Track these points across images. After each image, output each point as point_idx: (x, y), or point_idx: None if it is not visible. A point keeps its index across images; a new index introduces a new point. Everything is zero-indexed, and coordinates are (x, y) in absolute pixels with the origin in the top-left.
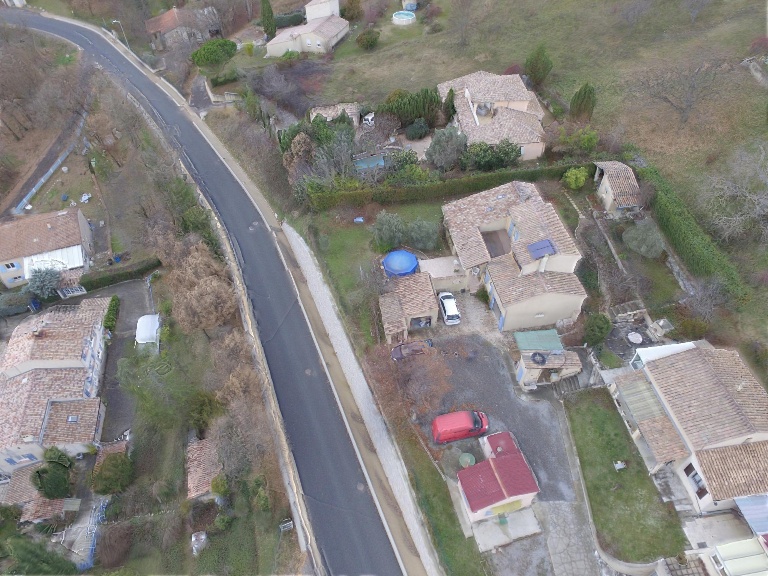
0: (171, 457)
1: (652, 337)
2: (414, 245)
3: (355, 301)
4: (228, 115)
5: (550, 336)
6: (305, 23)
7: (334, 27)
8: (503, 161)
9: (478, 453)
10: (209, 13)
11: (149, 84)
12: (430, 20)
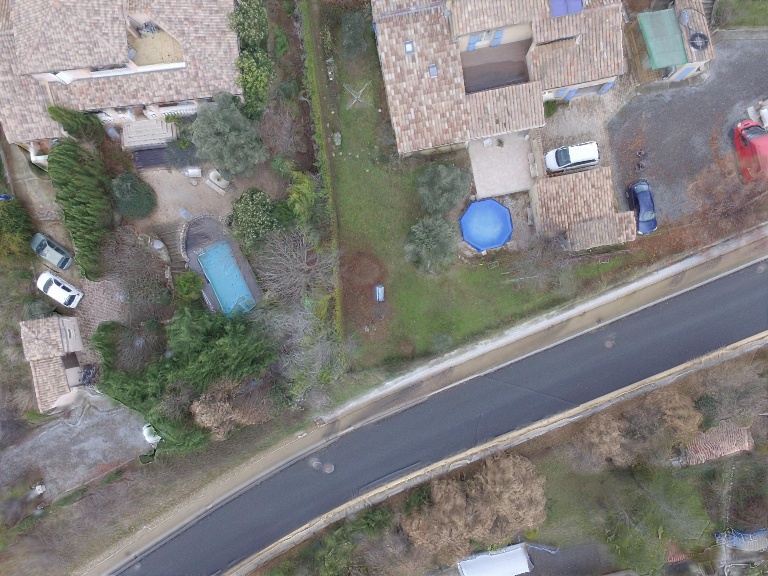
0: None
1: None
2: None
3: None
4: None
5: (653, 22)
6: None
7: None
8: None
9: None
10: None
11: None
12: None
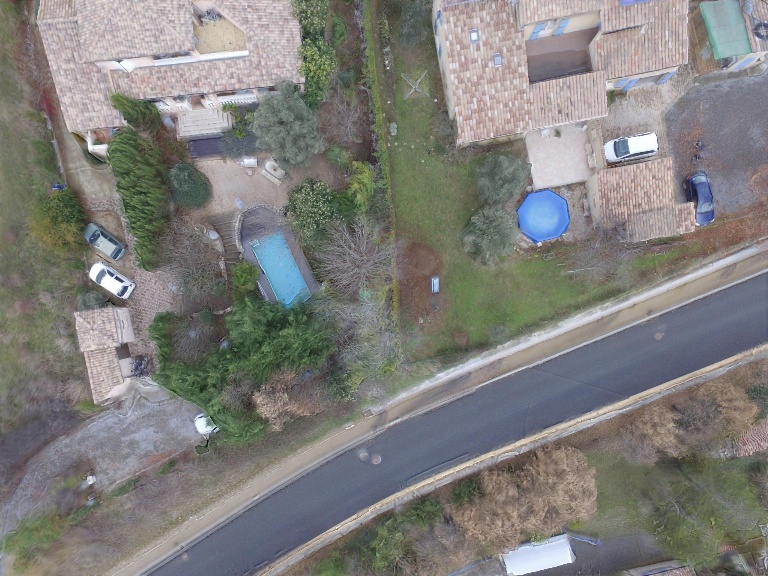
0: None
1: None
2: None
3: None
4: (57, 572)
5: (716, 11)
6: None
7: None
8: None
9: None
10: None
11: None
12: None
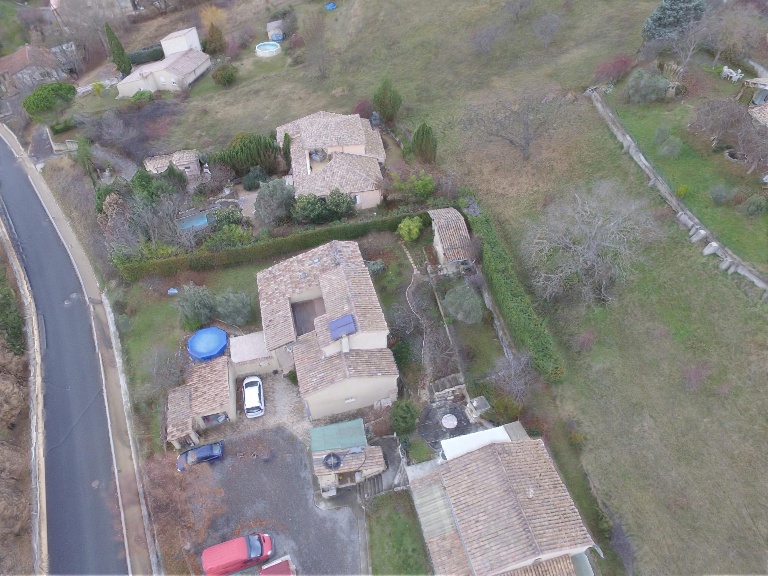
0: None
1: (470, 418)
2: (225, 320)
3: (143, 398)
4: (62, 167)
5: (353, 428)
6: (162, 59)
7: (191, 62)
8: (338, 212)
9: None
10: (60, 51)
11: None
12: (293, 51)
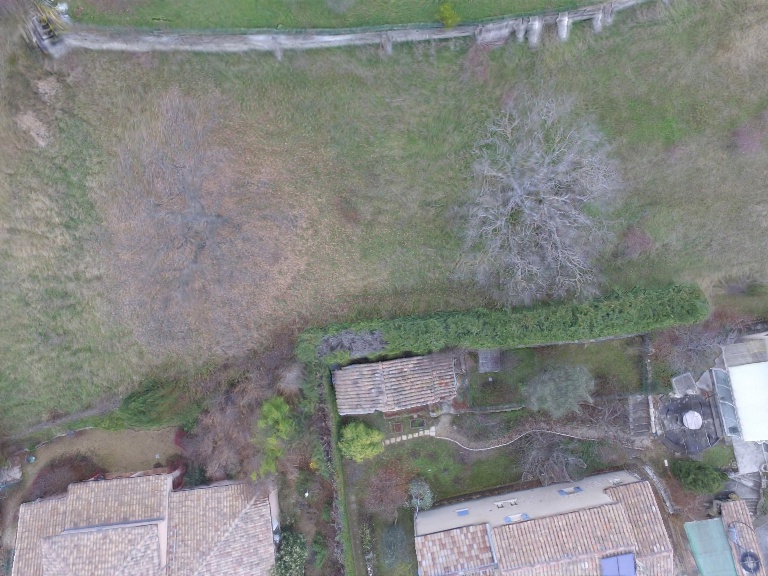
0: None
1: None
2: None
3: None
4: None
5: (701, 535)
6: None
7: None
8: None
9: None
10: None
11: None
12: None
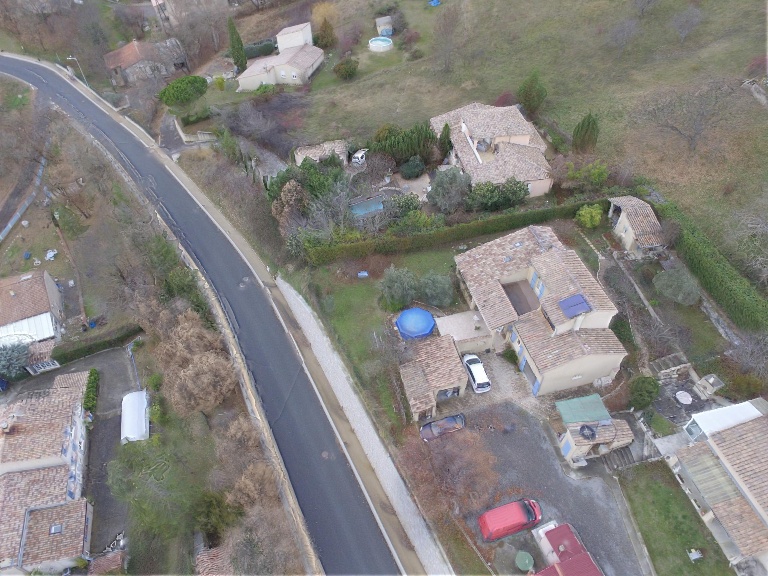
0: (175, 567)
1: (701, 395)
2: (428, 301)
3: (373, 373)
4: (204, 157)
5: (594, 403)
6: (277, 53)
7: (309, 57)
8: (510, 200)
9: (534, 549)
10: (173, 45)
11: (113, 124)
12: (409, 46)
